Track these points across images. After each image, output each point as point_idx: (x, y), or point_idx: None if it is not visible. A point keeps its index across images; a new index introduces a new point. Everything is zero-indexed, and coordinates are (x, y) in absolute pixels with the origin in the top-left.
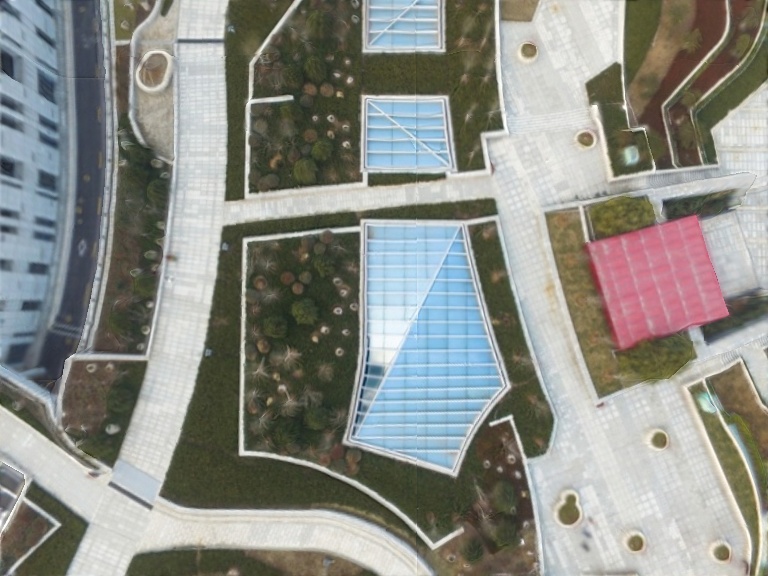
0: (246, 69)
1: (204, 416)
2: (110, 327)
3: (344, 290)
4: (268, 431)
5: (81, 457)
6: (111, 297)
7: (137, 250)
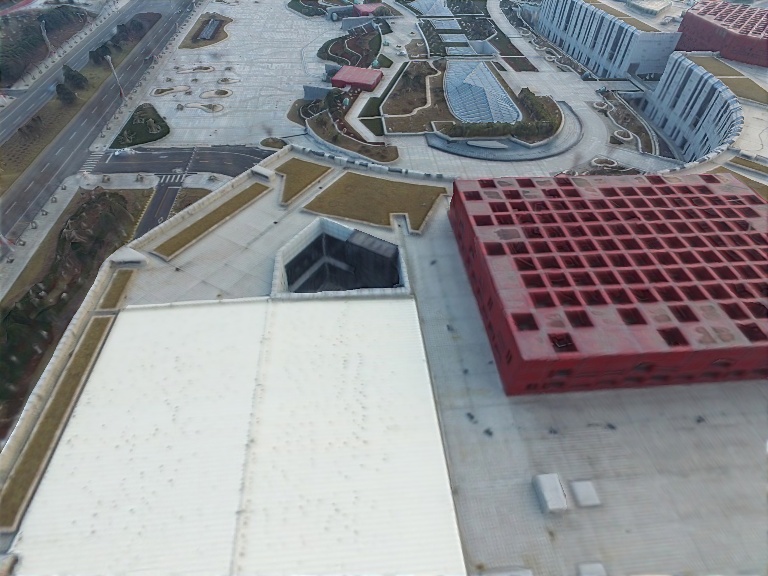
0: (498, 32)
1: (482, 3)
2: None
3: None
4: None
5: None
6: None
7: None
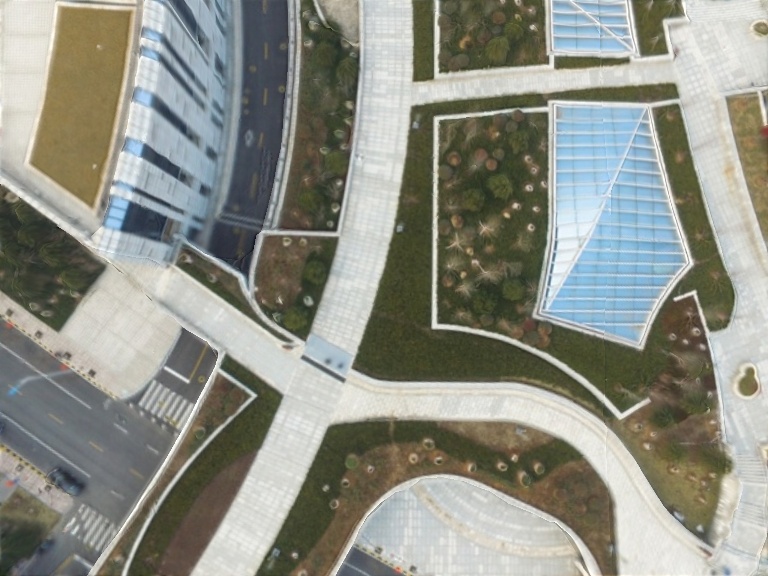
0: None
1: (396, 291)
2: (297, 206)
3: (534, 168)
4: (470, 299)
5: (275, 330)
6: (296, 177)
7: (324, 129)
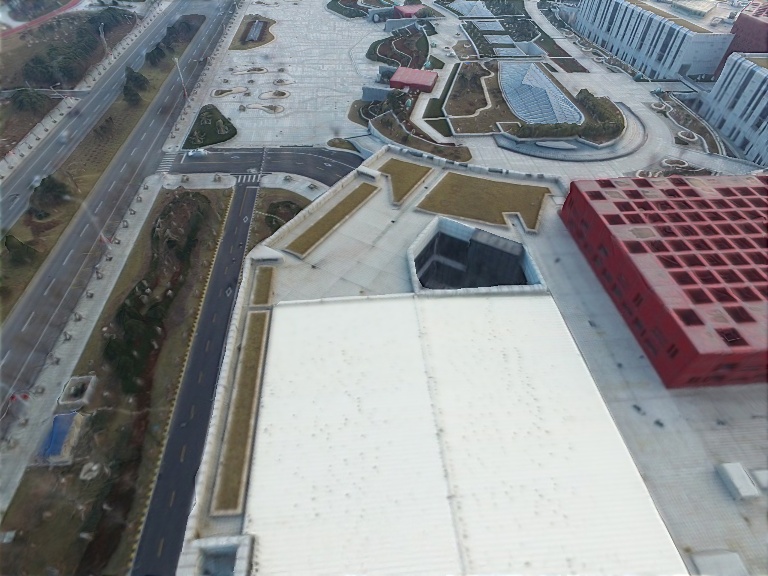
0: None
1: None
2: None
3: None
4: None
5: None
6: None
7: None
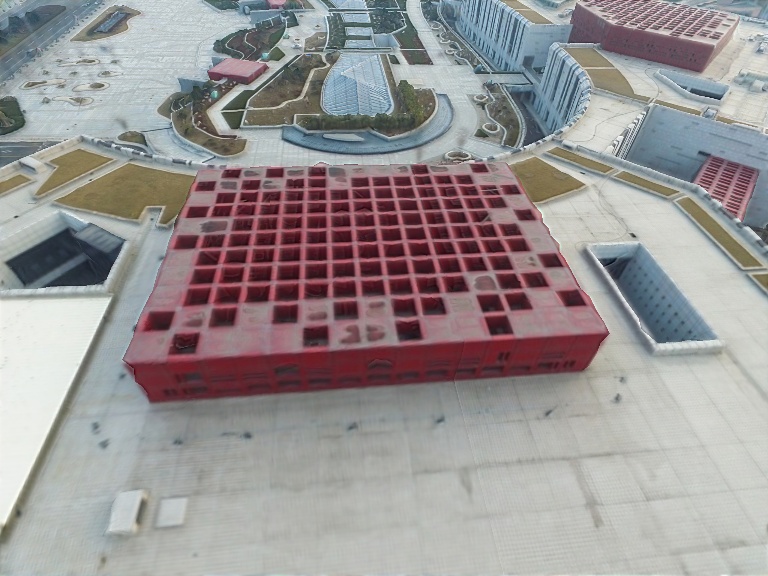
0: None
1: None
2: None
3: (370, 3)
4: None
5: None
6: None
7: None
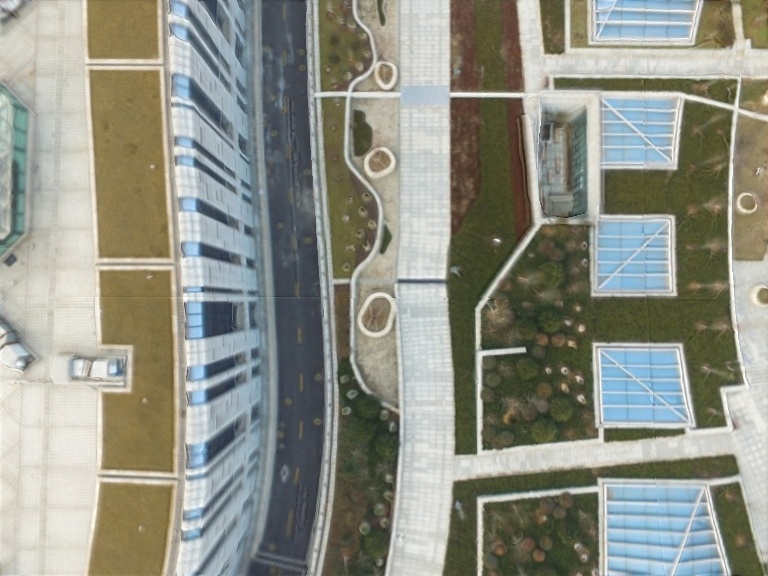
0: (472, 314)
1: None
2: None
3: (584, 555)
4: None
5: None
6: (335, 549)
7: (364, 503)
